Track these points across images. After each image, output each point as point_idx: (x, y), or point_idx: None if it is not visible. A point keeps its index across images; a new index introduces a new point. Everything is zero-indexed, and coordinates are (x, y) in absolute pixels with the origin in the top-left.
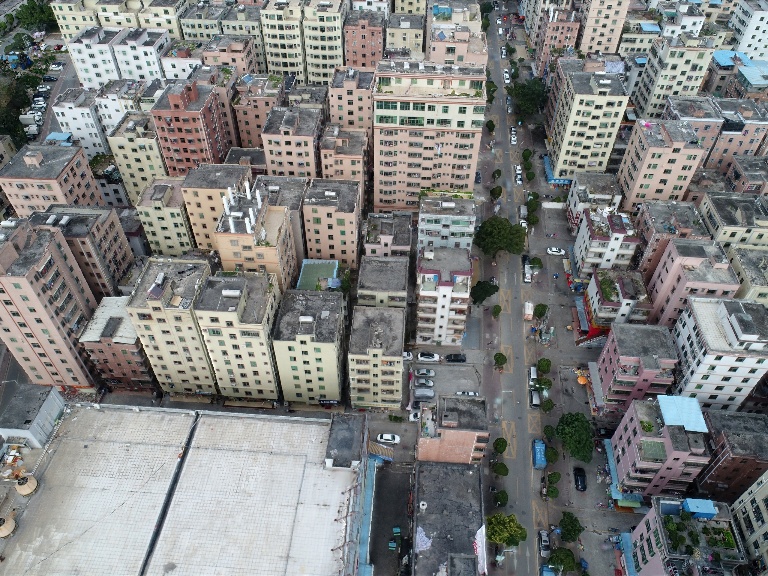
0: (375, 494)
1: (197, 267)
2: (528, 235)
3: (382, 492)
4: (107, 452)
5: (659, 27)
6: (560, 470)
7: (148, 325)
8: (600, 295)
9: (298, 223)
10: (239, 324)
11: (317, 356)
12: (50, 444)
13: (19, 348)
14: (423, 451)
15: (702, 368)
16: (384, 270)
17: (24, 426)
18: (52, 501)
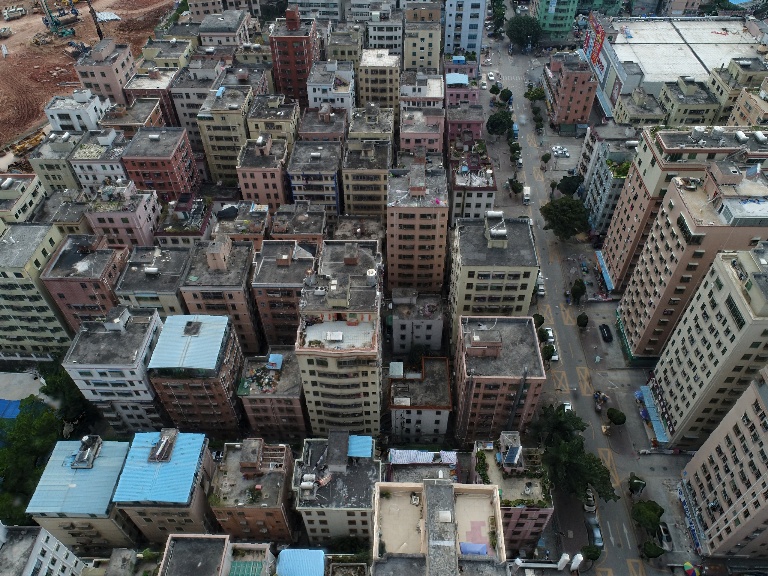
0: None
1: None
2: None
3: None
4: None
5: (277, 570)
6: None
7: None
8: None
9: None
10: None
11: None
12: None
13: None
14: None
15: None
16: None
17: None
18: None
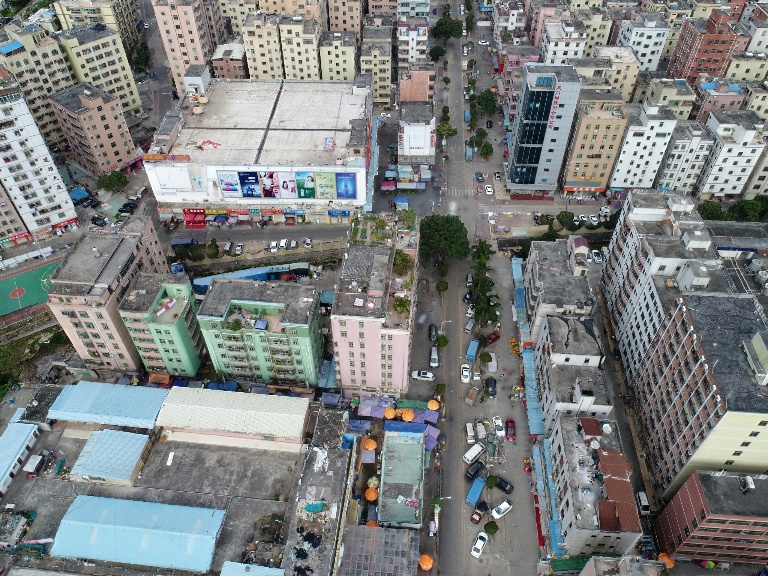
0: (378, 136)
1: (275, 14)
2: (467, 37)
3: (382, 135)
4: (239, 93)
5: None
6: (479, 122)
7: (252, 41)
8: (502, 40)
9: (325, 11)
10: (302, 34)
11: (344, 58)
12: (209, 92)
13: (176, 66)
14: (403, 93)
15: (549, 54)
16: (377, 33)
17: (198, 76)
18: (217, 107)
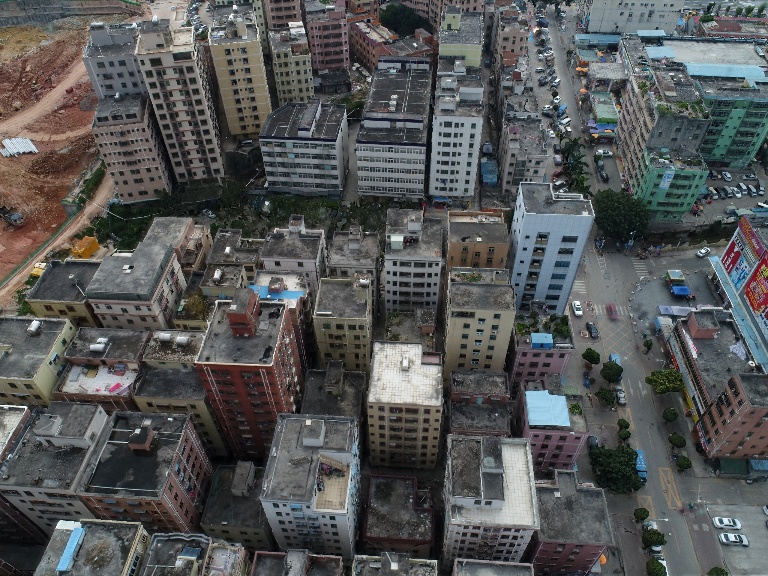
0: None
1: None
2: None
3: None
4: None
5: None
6: None
7: None
8: None
9: None
10: None
11: None
12: None
13: None
14: None
15: None
16: None
17: None
18: None
